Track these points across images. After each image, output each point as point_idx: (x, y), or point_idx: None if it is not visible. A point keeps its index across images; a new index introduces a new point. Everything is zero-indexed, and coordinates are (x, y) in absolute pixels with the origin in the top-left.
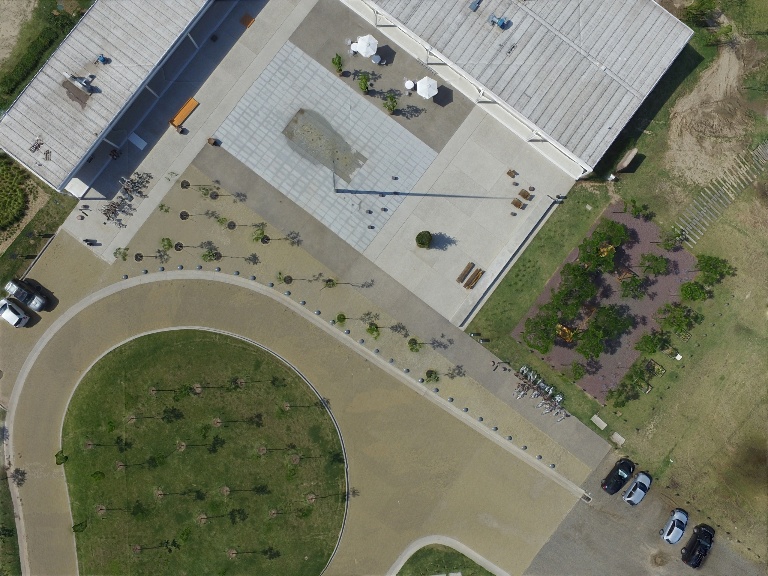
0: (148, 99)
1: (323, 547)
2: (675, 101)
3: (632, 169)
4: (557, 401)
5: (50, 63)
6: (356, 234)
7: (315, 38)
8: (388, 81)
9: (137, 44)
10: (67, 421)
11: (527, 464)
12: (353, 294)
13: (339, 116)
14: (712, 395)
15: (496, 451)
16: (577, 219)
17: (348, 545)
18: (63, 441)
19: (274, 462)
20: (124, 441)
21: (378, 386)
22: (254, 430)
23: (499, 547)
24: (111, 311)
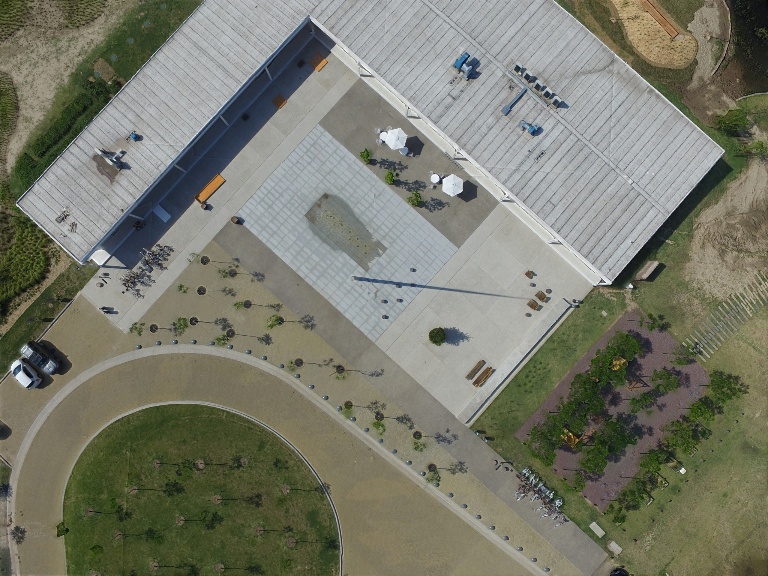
0: (176, 174)
1: None
2: (700, 212)
3: (651, 278)
4: (557, 506)
5: (83, 136)
6: (370, 322)
7: (345, 124)
8: (414, 172)
9: (169, 123)
10: (70, 484)
11: (522, 566)
12: (362, 382)
13: (362, 203)
14: (714, 512)
15: (492, 550)
16: (592, 324)
17: None
18: (65, 503)
19: (270, 543)
20: (125, 510)
21: (379, 476)
22: (253, 510)
23: None
24: (122, 379)
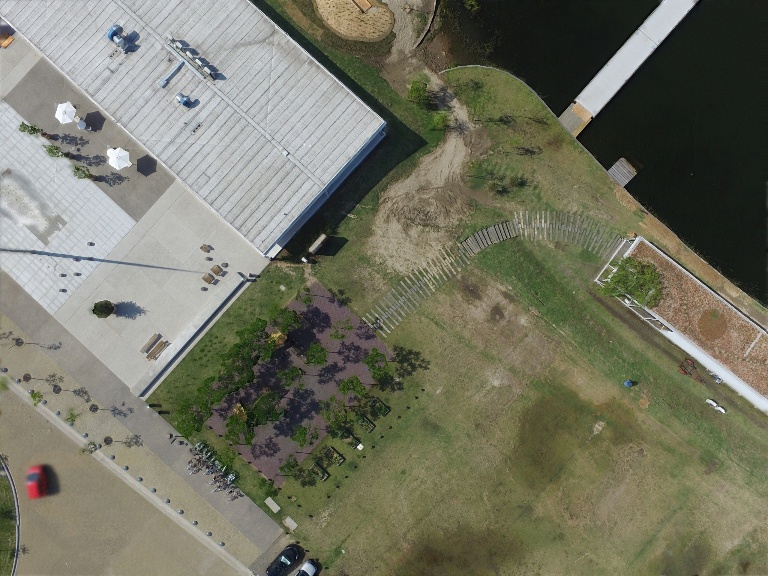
0: None
1: None
2: (387, 186)
3: (332, 252)
4: (230, 480)
5: None
6: (49, 296)
7: (29, 100)
8: (95, 147)
9: None
10: None
11: (197, 540)
12: (40, 355)
13: (44, 178)
14: (391, 489)
15: (167, 523)
16: (269, 299)
17: None
18: None
19: None
20: None
21: (57, 448)
22: None
23: None
24: None
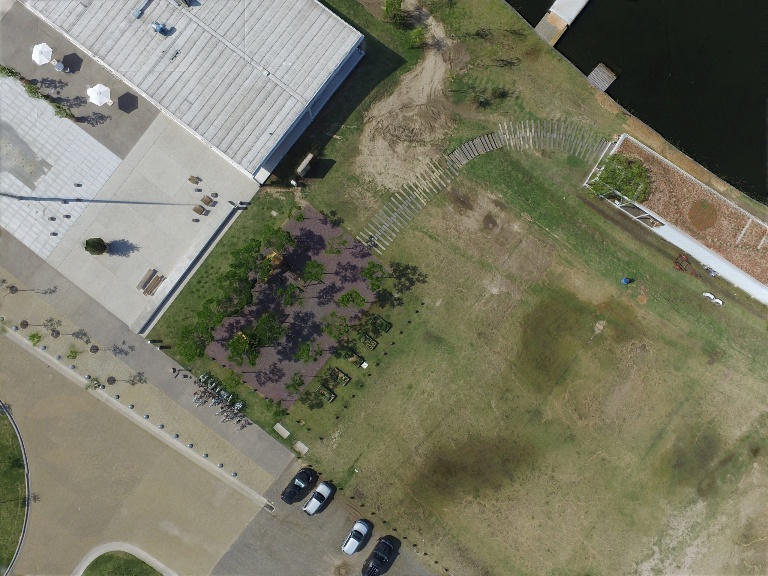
0: None
1: (3, 552)
2: (370, 105)
3: (321, 175)
4: (237, 409)
5: None
6: (40, 241)
7: (4, 47)
8: (74, 89)
9: None
10: None
11: (208, 472)
12: (36, 301)
13: (26, 124)
14: (399, 404)
15: (177, 459)
16: (262, 225)
17: (29, 550)
18: None
19: None
20: None
21: (60, 392)
22: None
23: (180, 555)
24: None
